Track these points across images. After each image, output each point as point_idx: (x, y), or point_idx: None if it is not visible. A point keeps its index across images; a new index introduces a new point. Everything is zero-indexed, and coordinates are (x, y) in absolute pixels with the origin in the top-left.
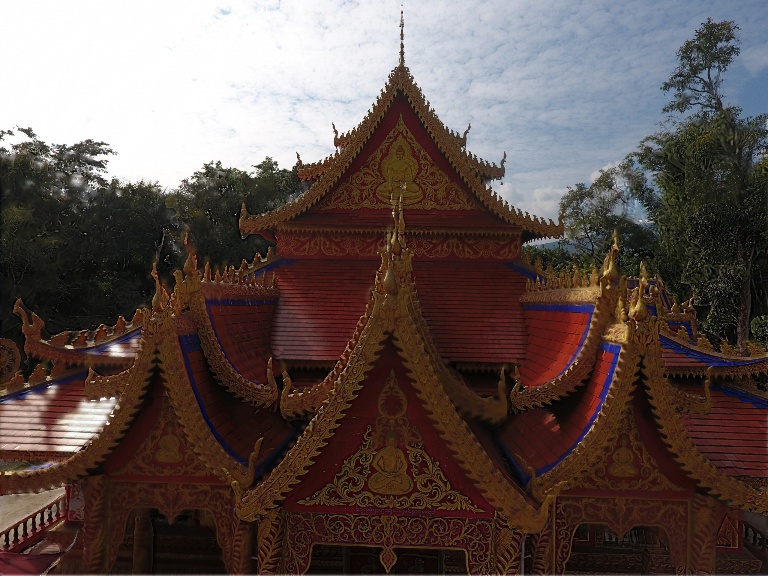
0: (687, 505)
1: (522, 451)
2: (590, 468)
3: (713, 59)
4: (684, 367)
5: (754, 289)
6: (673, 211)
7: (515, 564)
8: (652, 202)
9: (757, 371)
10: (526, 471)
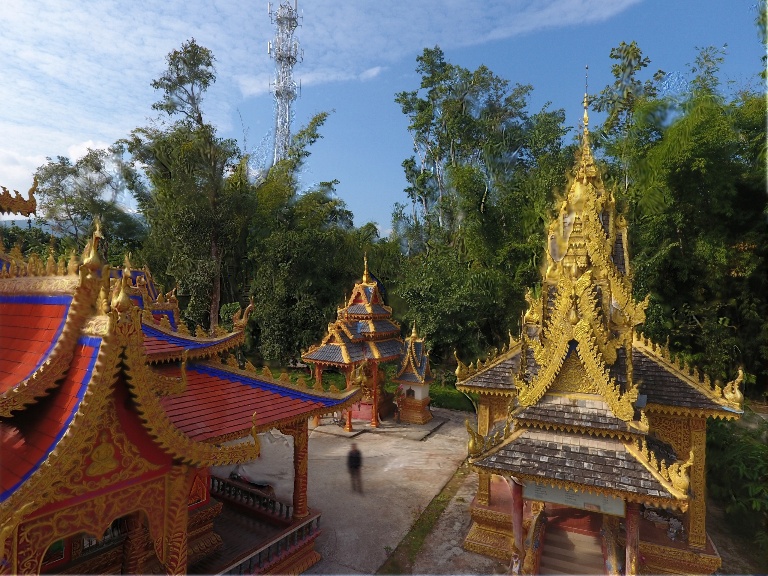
0: (165, 479)
1: None
2: (64, 477)
3: (196, 77)
4: (165, 353)
5: (223, 282)
6: (161, 206)
7: None
8: (142, 194)
9: (221, 349)
10: None
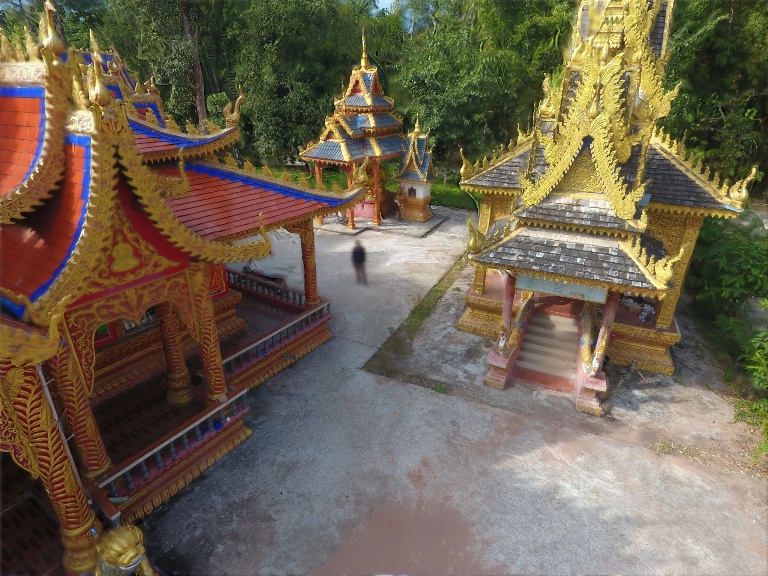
0: (186, 274)
1: (3, 281)
2: (92, 273)
3: None
4: (159, 151)
5: (204, 67)
6: None
7: (37, 396)
8: None
9: (217, 147)
10: (17, 301)
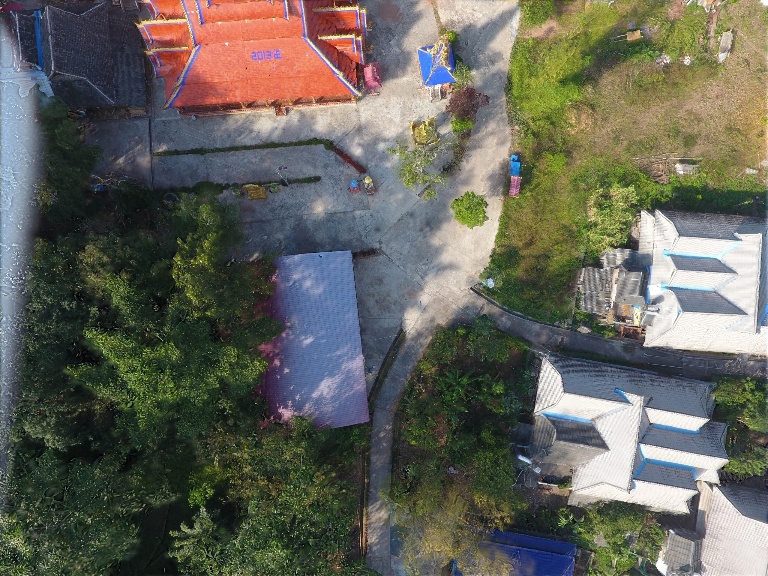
0: None
1: None
2: None
3: None
4: None
5: None
6: None
7: None
8: None
9: None
10: None
